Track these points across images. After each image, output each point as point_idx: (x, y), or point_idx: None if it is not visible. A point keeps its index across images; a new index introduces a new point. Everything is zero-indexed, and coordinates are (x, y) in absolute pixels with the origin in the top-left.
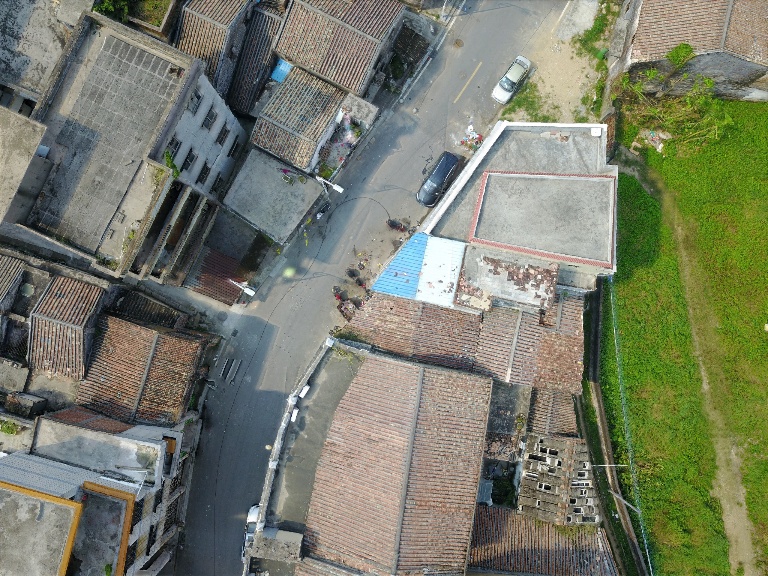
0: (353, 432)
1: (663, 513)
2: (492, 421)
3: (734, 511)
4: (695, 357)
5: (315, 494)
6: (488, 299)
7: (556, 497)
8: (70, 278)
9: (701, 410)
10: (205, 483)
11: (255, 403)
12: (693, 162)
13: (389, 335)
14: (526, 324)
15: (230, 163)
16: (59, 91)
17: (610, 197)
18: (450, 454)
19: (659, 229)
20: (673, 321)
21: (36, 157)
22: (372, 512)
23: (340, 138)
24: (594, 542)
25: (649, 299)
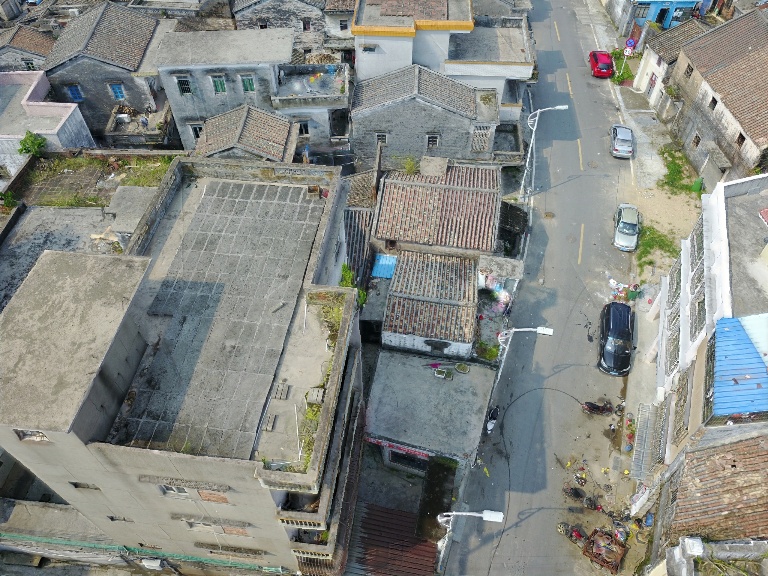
0: None
1: None
2: None
3: None
4: None
5: None
6: None
7: None
8: None
9: None
10: None
11: None
12: None
13: (764, 509)
14: None
15: None
16: (145, 255)
17: None
18: None
19: None
20: None
21: (129, 316)
22: None
23: (484, 313)
24: None
25: None
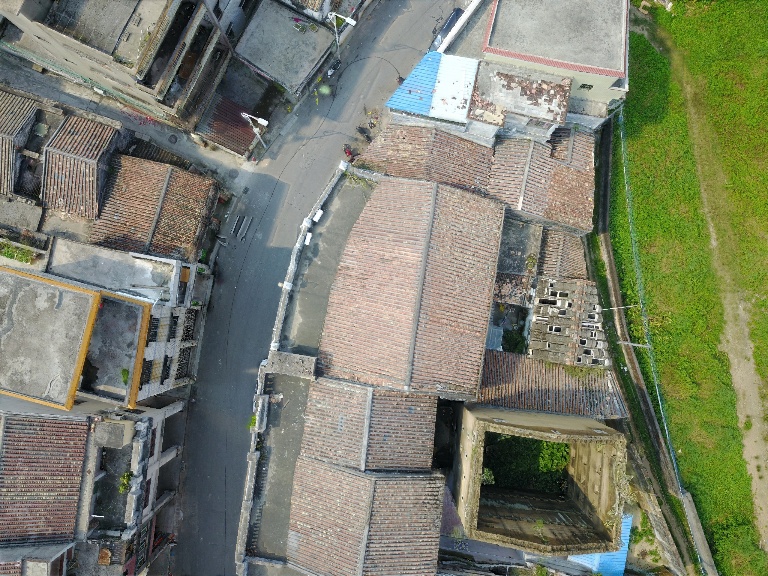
0: (366, 254)
1: (671, 366)
2: (503, 262)
3: (742, 365)
4: (703, 213)
5: (329, 318)
6: (501, 114)
7: (566, 338)
8: (83, 118)
9: (709, 265)
10: (217, 338)
11: (266, 259)
12: (702, 21)
13: (402, 163)
14: (538, 154)
15: (241, 18)
16: None
17: (623, 8)
18: (463, 275)
19: (668, 85)
20: (682, 176)
21: None
22: (386, 329)
23: None
24: (604, 384)
25: (658, 154)
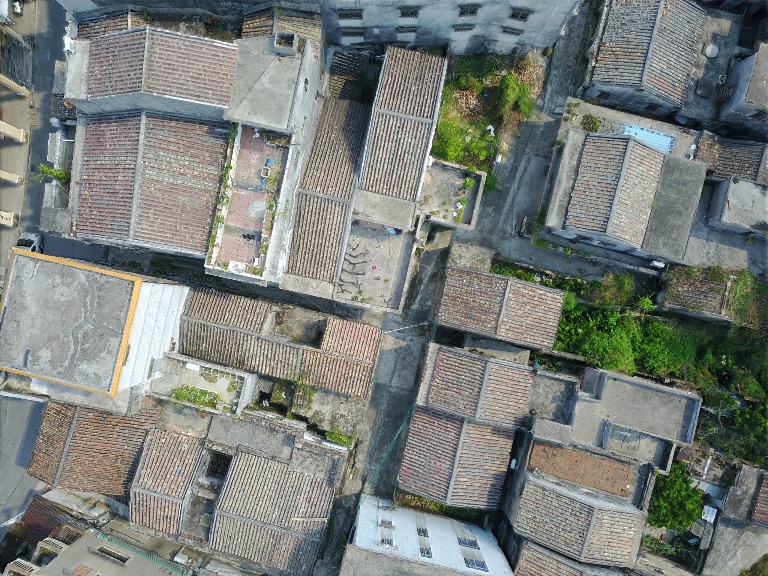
0: None
1: None
2: None
3: None
4: None
5: None
6: None
7: None
8: None
9: None
10: None
11: None
12: None
13: None
14: None
15: None
16: None
17: None
18: None
19: None
20: None
21: None
22: None
23: None
24: None
25: None
